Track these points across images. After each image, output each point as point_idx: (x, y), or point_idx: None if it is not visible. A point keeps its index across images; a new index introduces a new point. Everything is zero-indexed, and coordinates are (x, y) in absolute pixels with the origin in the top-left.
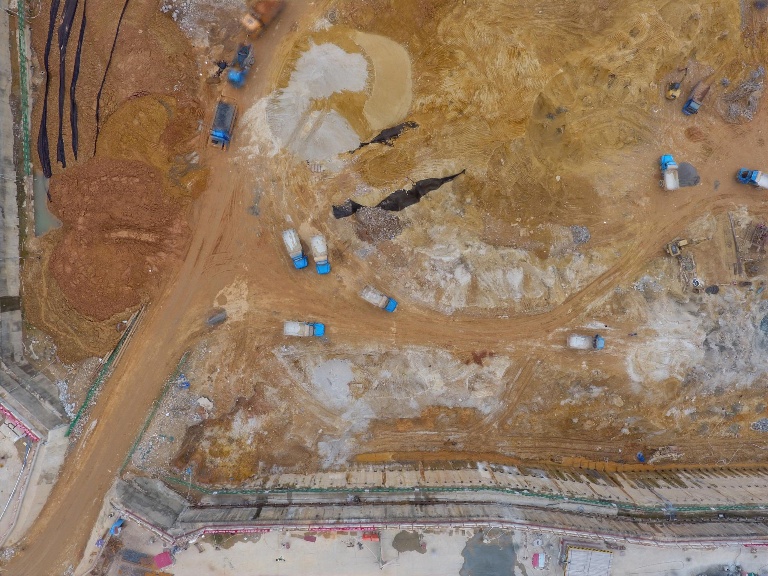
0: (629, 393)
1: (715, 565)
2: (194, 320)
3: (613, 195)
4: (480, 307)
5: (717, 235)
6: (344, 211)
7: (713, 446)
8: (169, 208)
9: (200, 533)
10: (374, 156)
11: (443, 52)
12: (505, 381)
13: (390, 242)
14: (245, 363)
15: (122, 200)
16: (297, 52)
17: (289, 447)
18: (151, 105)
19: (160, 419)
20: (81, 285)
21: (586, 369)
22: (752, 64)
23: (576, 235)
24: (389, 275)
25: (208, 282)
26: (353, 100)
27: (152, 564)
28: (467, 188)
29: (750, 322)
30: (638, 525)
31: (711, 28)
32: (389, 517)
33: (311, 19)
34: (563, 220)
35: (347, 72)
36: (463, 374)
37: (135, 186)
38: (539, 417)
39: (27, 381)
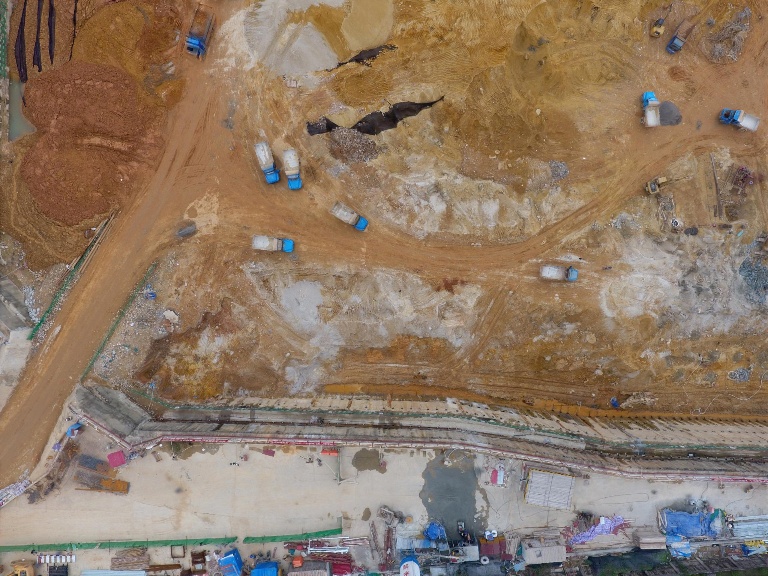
0: (603, 331)
1: (681, 499)
2: (163, 231)
3: (593, 131)
4: (453, 233)
5: (698, 176)
6: (318, 128)
7: (689, 394)
8: (143, 117)
9: (157, 441)
10: (351, 74)
11: None
12: (476, 311)
13: (364, 164)
14: (213, 277)
15: (96, 105)
16: None
17: (255, 368)
18: (128, 10)
19: (124, 328)
20: (50, 188)
21: (559, 302)
22: (739, 5)
23: (554, 169)
24: (361, 194)
25: (179, 194)
26: (331, 15)
27: (108, 471)
28: (445, 116)
29: (729, 266)
30: (605, 458)
31: None
32: (350, 435)
33: None
34: (542, 154)
35: None
36: (433, 301)
37: (109, 91)
38: (511, 353)
39: None
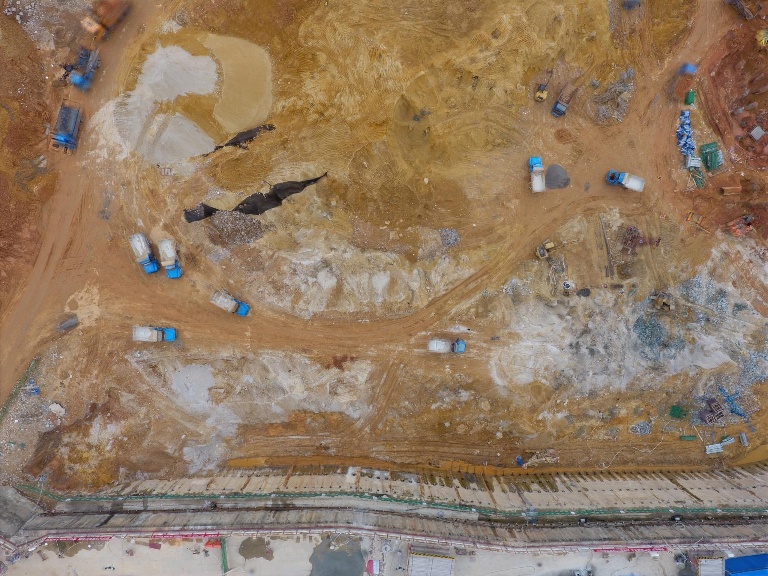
0: (497, 397)
1: (567, 570)
2: (44, 325)
3: (482, 197)
4: (339, 311)
5: (588, 237)
6: (196, 215)
7: (593, 449)
8: (16, 212)
9: (41, 541)
10: (226, 159)
11: (304, 54)
12: (369, 385)
13: (247, 246)
14: (98, 369)
15: None
16: (144, 55)
17: (149, 453)
18: None
19: (8, 426)
20: None
21: (449, 373)
22: (622, 65)
23: (444, 238)
24: (242, 279)
25: (58, 287)
26: (200, 103)
27: None
28: (331, 191)
29: (623, 325)
30: (495, 530)
31: (578, 29)
32: (236, 524)
33: (159, 21)
34: (432, 223)
35: (191, 75)
36: (324, 378)
37: None
38: (410, 421)
39: None
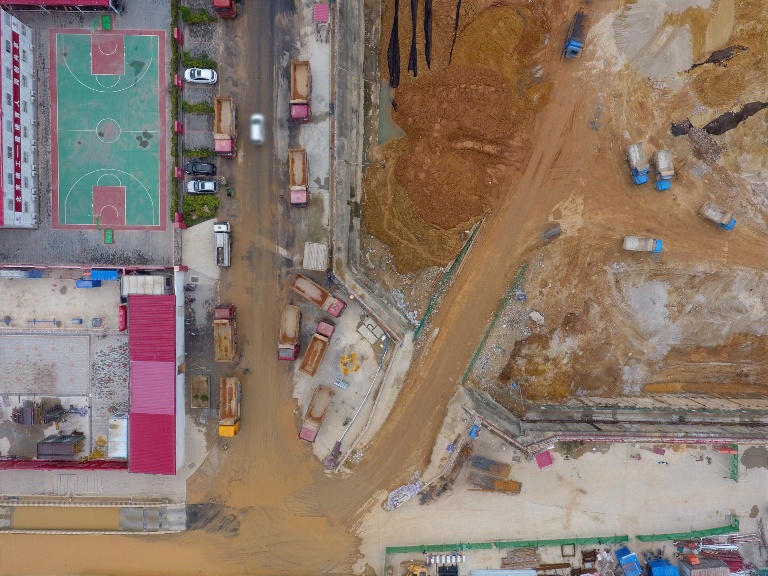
0: None
1: None
2: (531, 233)
3: None
4: None
5: None
6: (682, 129)
7: None
8: (514, 120)
9: (554, 441)
10: (714, 75)
11: None
12: None
13: (717, 164)
14: (577, 278)
15: (475, 109)
16: None
17: (605, 368)
18: (512, 15)
19: (498, 330)
20: (435, 191)
21: None
22: None
23: None
24: (724, 194)
25: (545, 196)
26: (703, 17)
27: (501, 471)
28: None
29: None
30: None
31: None
32: (736, 433)
33: None
34: None
35: None
36: None
37: (490, 95)
38: None
39: (376, 286)
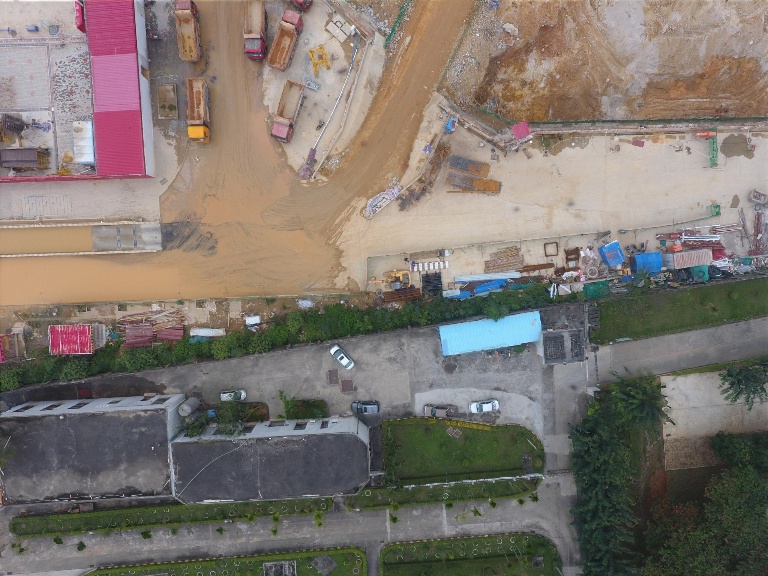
0: None
1: None
2: None
3: None
4: None
5: None
6: None
7: None
8: None
9: None
10: None
11: None
12: None
13: None
14: None
15: None
16: None
17: (582, 90)
18: None
19: (471, 38)
20: None
21: None
22: None
23: None
24: None
25: None
26: None
27: (480, 171)
28: None
29: None
30: None
31: None
32: None
33: None
34: None
35: None
36: (759, 10)
37: None
38: None
39: None
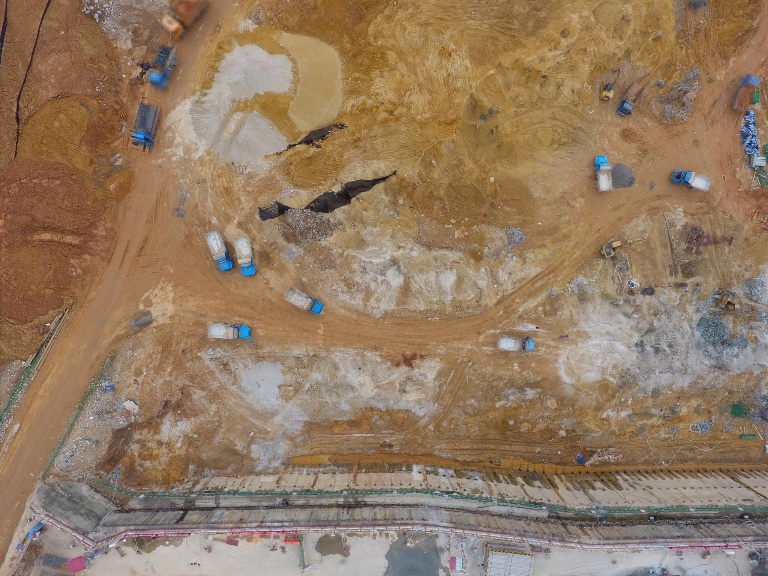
0: (563, 395)
1: (641, 568)
2: (119, 323)
3: (548, 196)
4: (410, 309)
5: (653, 236)
6: (270, 213)
7: (653, 448)
8: (92, 210)
9: (120, 537)
10: (300, 158)
11: (374, 53)
12: (437, 383)
13: (319, 244)
14: (171, 366)
15: (43, 202)
16: (221, 53)
17: (219, 450)
18: (71, 107)
19: (84, 422)
20: (2, 288)
21: (518, 371)
22: (687, 65)
23: (510, 236)
24: (316, 277)
25: (133, 284)
26: (277, 101)
27: None
28: (399, 189)
29: (686, 323)
30: (566, 528)
31: (645, 29)
32: (313, 520)
33: (235, 20)
34: (498, 221)
35: (269, 73)
36: (393, 376)
37: (56, 188)
38: (474, 419)
39: None
